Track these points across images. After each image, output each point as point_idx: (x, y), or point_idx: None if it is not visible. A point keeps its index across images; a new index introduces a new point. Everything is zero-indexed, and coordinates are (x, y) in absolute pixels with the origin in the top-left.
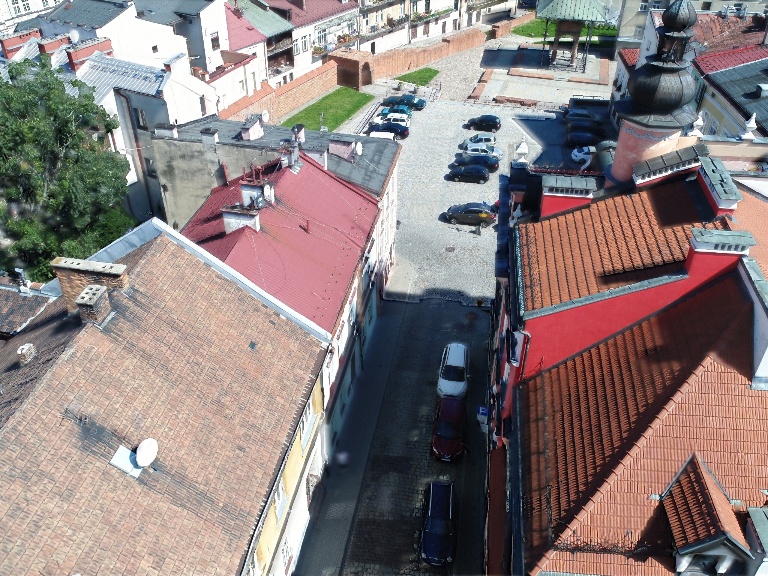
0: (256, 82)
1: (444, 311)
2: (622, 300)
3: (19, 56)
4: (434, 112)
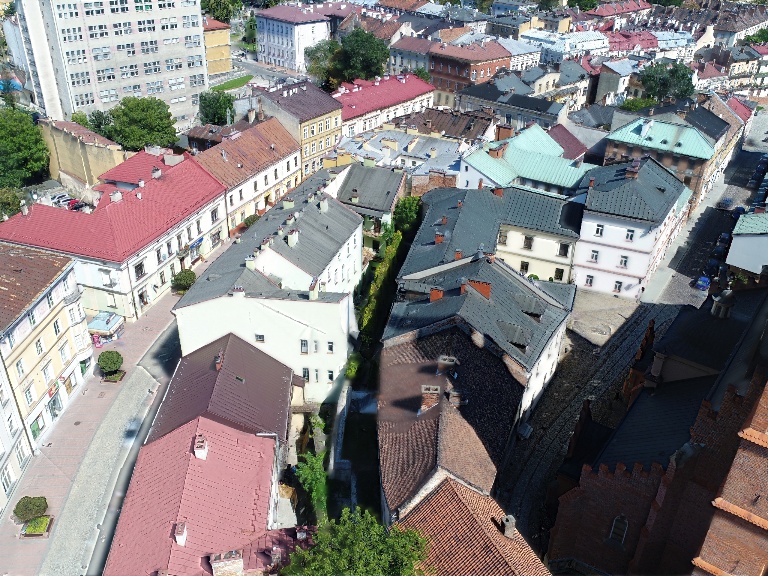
0: None
1: (762, 154)
2: None
3: (641, 66)
4: (762, 117)
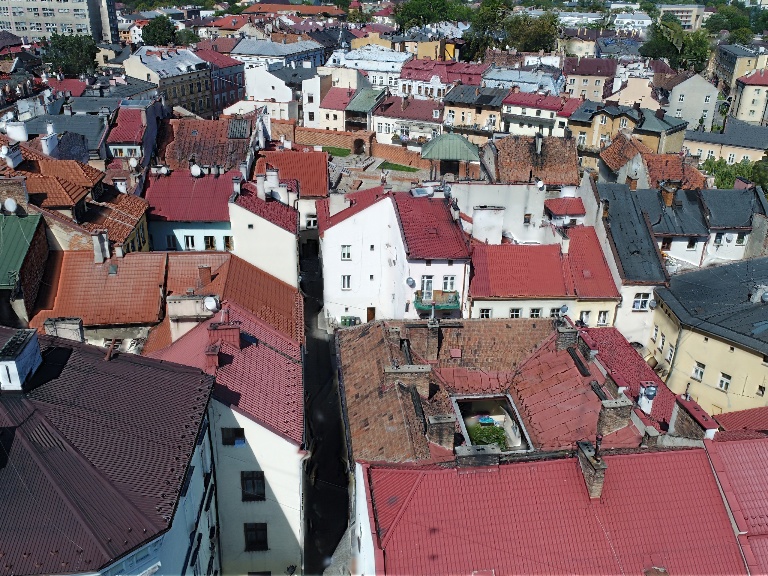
0: (285, 115)
1: None
2: None
3: None
4: None
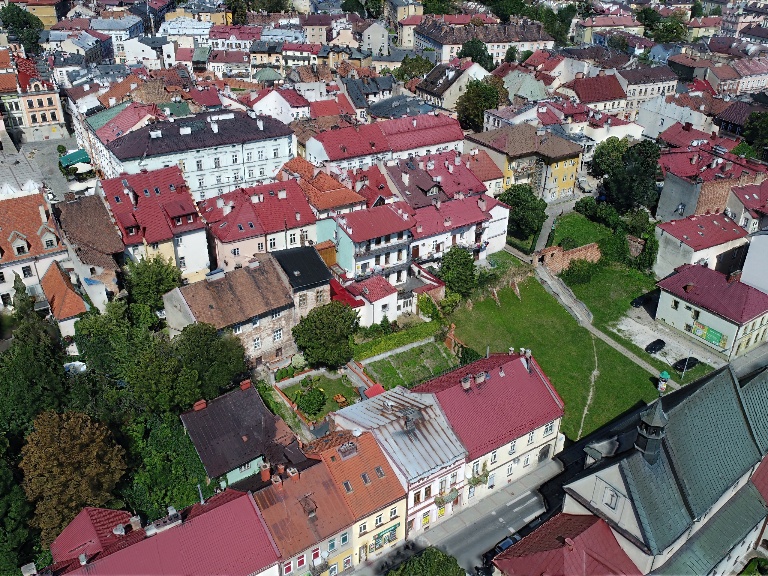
0: (159, 67)
1: None
2: None
3: None
4: None
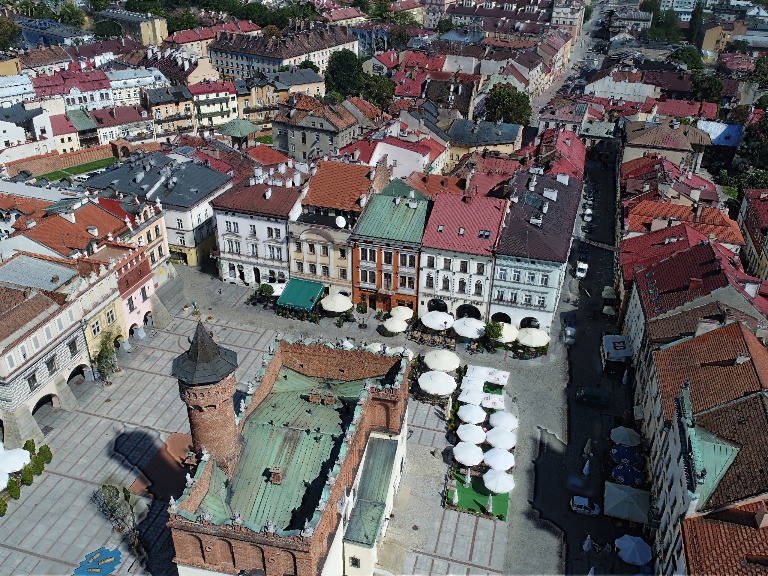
0: (48, 149)
1: None
2: None
3: None
4: None
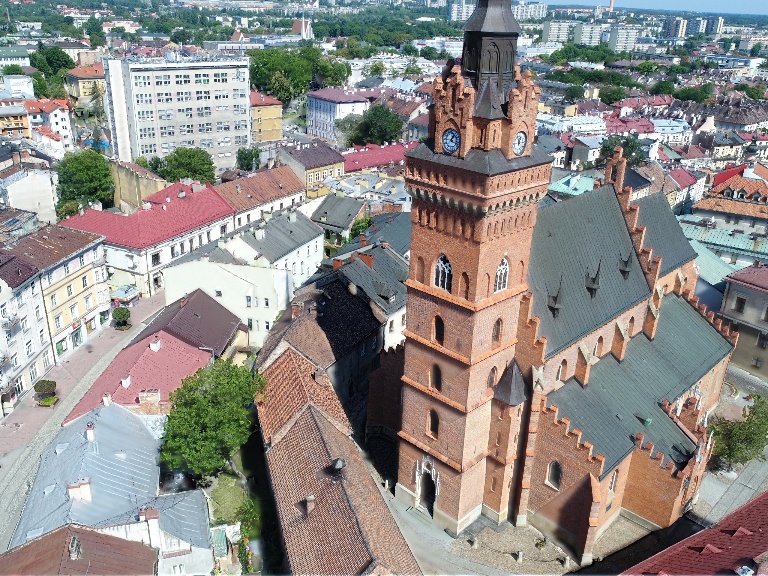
0: None
1: None
2: (731, 172)
3: None
4: None
